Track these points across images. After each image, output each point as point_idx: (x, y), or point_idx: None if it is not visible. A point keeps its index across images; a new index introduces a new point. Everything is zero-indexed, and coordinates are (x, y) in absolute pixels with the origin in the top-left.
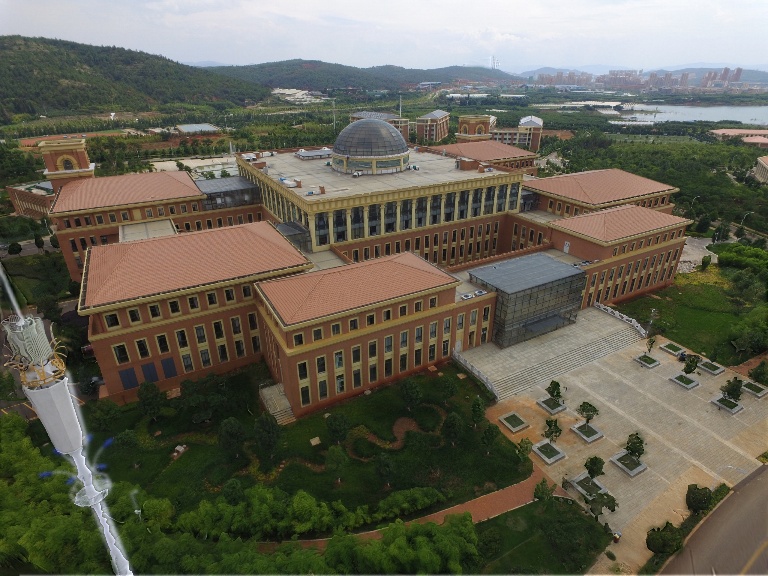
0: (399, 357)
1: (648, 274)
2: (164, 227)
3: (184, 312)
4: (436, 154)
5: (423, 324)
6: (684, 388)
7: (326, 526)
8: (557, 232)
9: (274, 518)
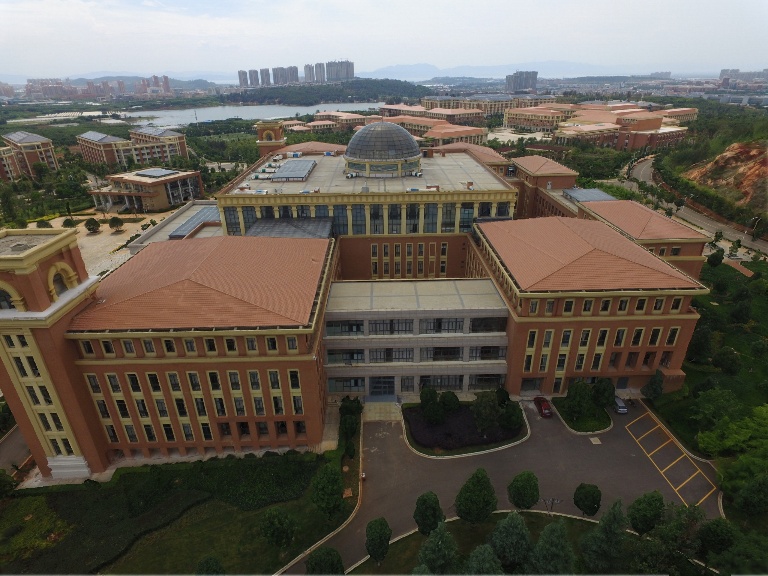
0: None
1: None
2: (364, 286)
3: None
4: None
5: None
6: None
7: None
8: (542, 178)
9: None
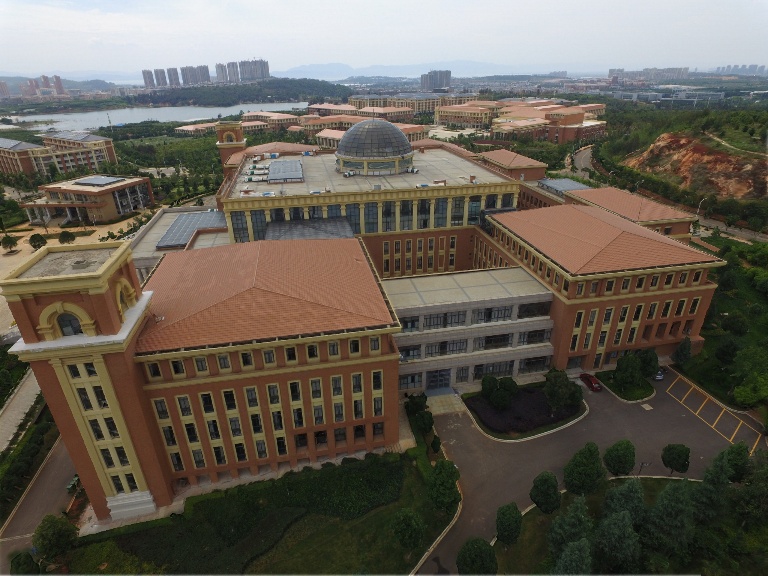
0: None
1: None
2: (405, 283)
3: None
4: None
5: None
6: None
7: None
8: (516, 170)
9: None
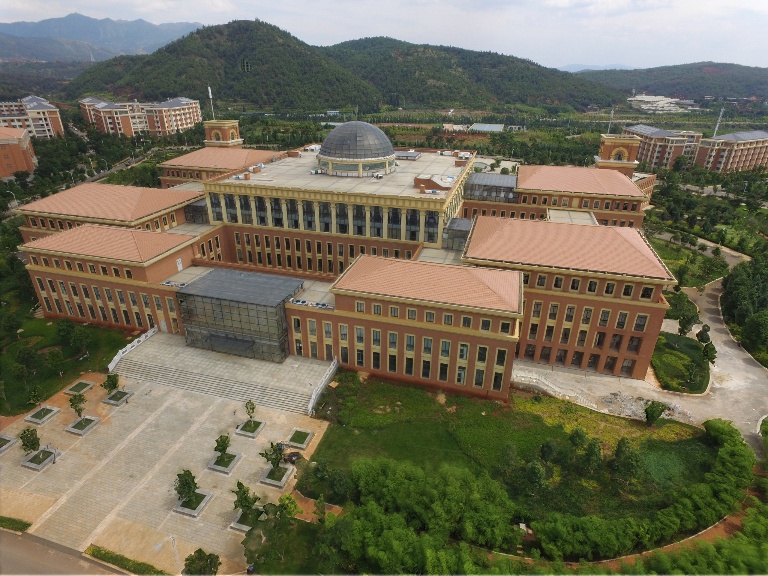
0: (109, 309)
1: (442, 363)
2: None
3: None
4: None
5: (121, 289)
6: None
7: None
8: None
9: None
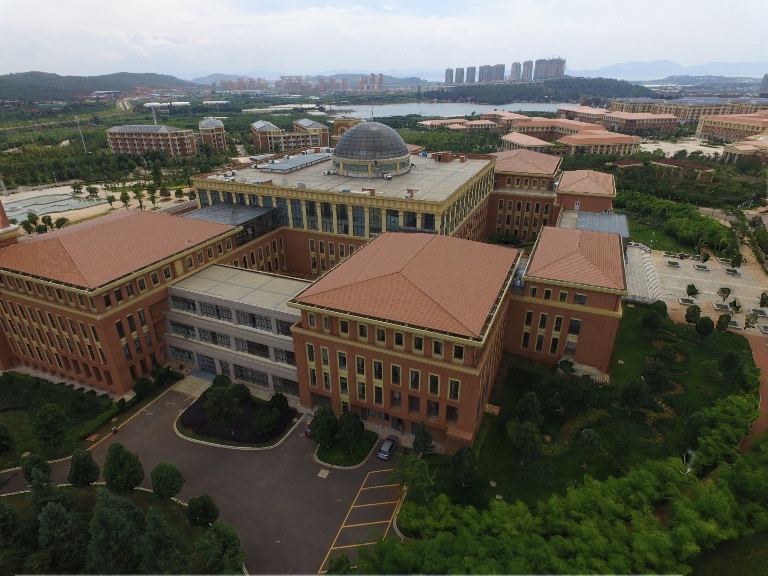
0: None
1: None
2: (231, 273)
3: None
4: None
5: None
6: (707, 271)
7: None
8: (568, 196)
9: None
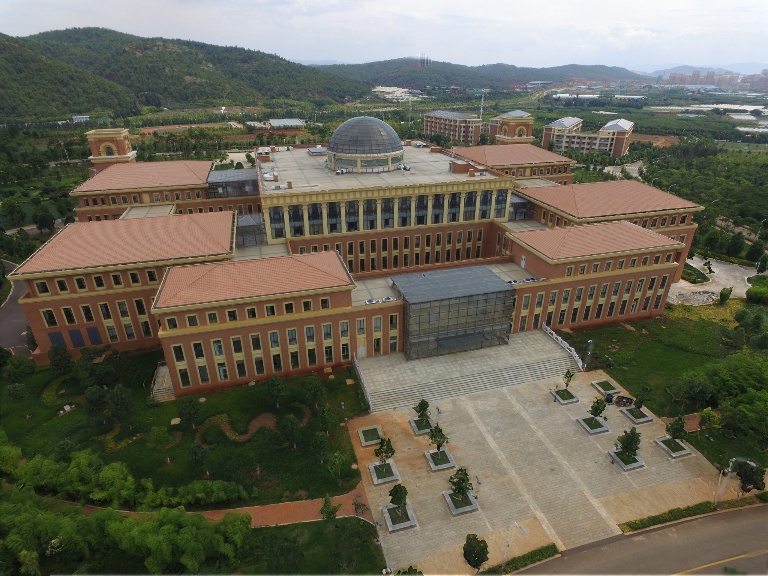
0: (288, 354)
1: (623, 301)
2: (163, 211)
3: (108, 287)
4: (447, 155)
5: (313, 324)
6: (587, 432)
7: (124, 499)
8: (516, 244)
9: (81, 482)
